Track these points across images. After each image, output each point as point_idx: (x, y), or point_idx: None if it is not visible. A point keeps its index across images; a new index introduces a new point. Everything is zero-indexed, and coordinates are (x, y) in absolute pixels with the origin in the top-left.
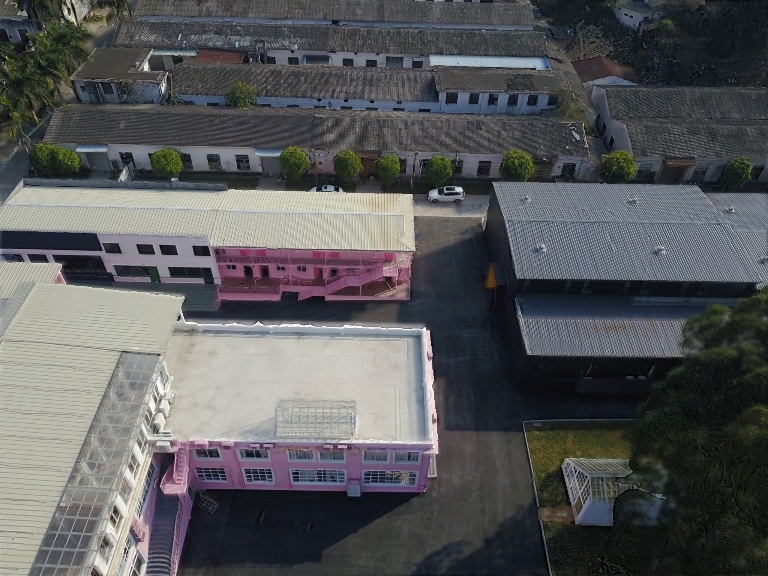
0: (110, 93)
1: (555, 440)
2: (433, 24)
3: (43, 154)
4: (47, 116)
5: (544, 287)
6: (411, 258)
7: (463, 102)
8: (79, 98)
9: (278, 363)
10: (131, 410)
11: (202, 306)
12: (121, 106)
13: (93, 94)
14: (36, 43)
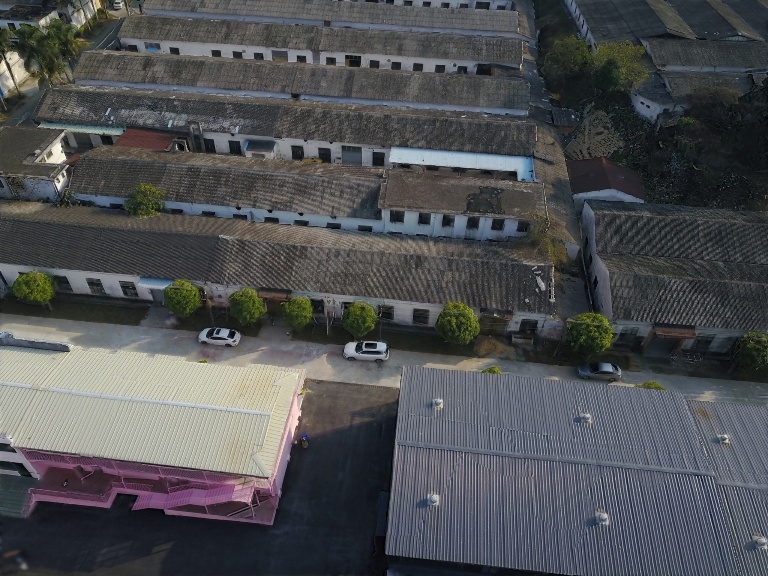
0: (0, 187)
1: None
2: (408, 103)
3: None
4: None
5: (428, 561)
6: (269, 480)
7: (411, 221)
8: None
9: None
10: None
11: (9, 510)
12: (5, 206)
13: None
14: None
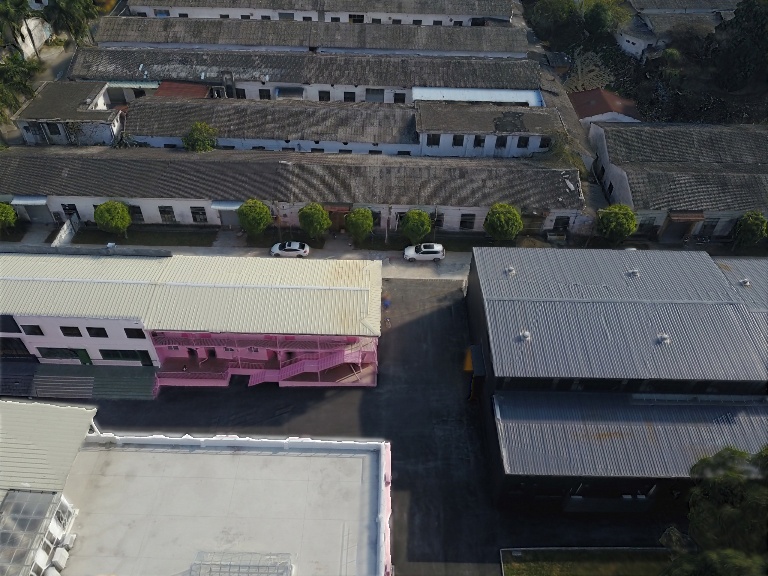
0: (57, 134)
1: (538, 575)
2: (418, 51)
3: None
4: None
5: (527, 383)
6: (376, 342)
7: (446, 144)
8: (23, 139)
9: (206, 489)
10: (8, 575)
11: (138, 394)
12: (67, 149)
13: (38, 135)
14: None
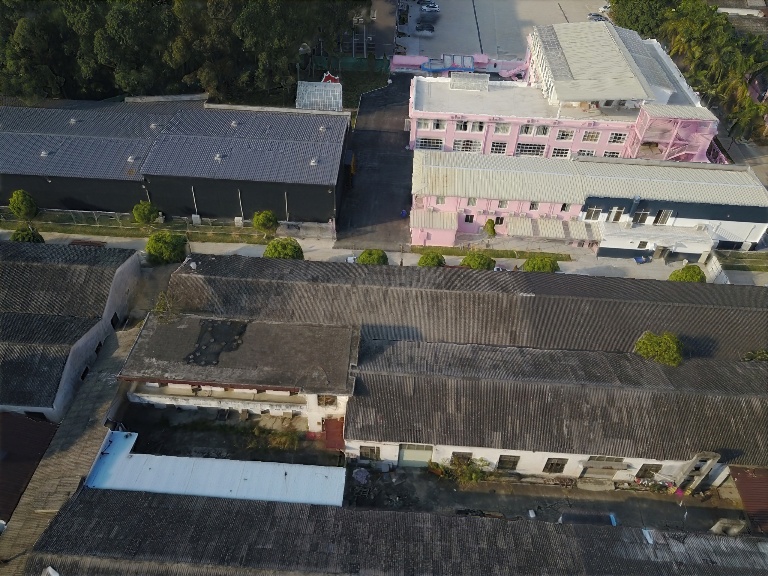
0: None
1: None
2: None
3: None
4: None
5: None
6: None
7: None
8: None
9: (496, 107)
10: None
11: None
12: None
13: None
14: None
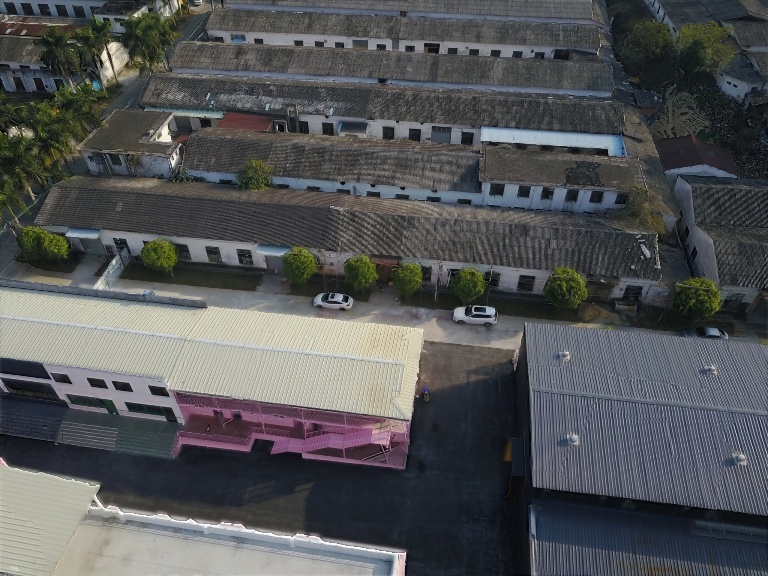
0: (118, 164)
1: None
2: (492, 86)
3: (29, 240)
4: (46, 191)
5: (571, 496)
6: (407, 424)
7: (511, 194)
8: (87, 167)
9: None
10: None
11: (159, 451)
12: (125, 182)
13: (101, 164)
14: (40, 113)
